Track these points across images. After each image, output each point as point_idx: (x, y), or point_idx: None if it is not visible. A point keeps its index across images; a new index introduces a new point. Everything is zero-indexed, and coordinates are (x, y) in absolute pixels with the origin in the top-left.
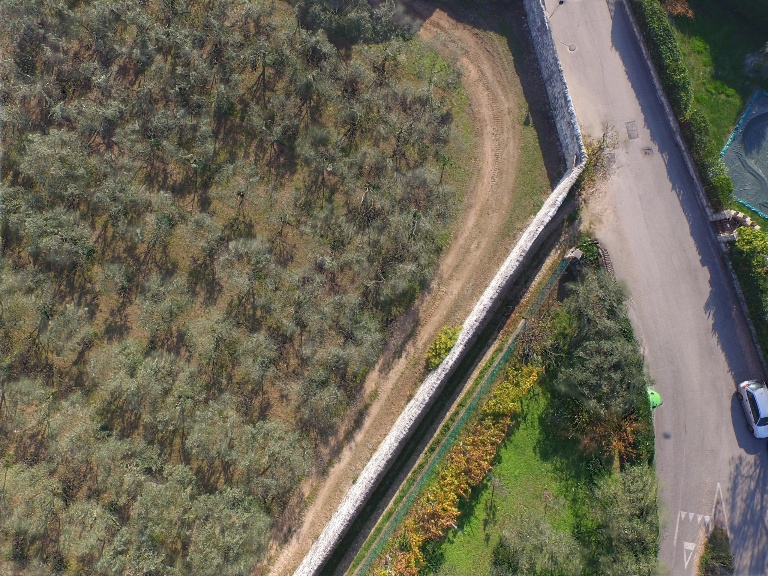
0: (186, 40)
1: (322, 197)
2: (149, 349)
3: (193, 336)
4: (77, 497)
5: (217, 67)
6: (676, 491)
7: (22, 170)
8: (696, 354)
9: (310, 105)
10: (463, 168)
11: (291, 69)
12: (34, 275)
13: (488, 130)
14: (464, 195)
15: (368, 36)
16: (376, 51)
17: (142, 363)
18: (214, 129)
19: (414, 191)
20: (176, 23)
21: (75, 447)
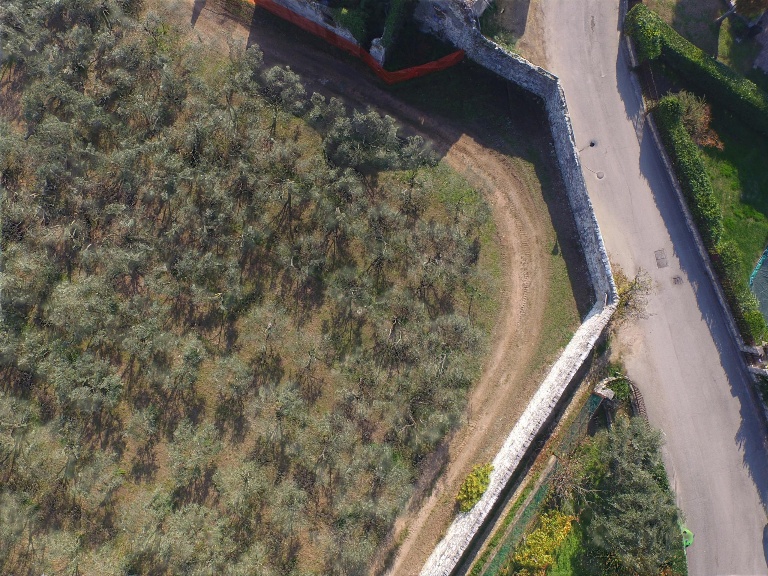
0: (214, 180)
1: (350, 329)
2: (177, 489)
3: (221, 475)
4: None
5: (245, 208)
6: None
7: (51, 322)
8: (727, 486)
9: (337, 234)
10: (491, 298)
11: (317, 197)
12: (60, 412)
13: (516, 259)
14: (493, 326)
15: (395, 165)
16: (402, 178)
17: (170, 504)
18: (240, 259)
19: (442, 323)
20: (204, 163)
21: None
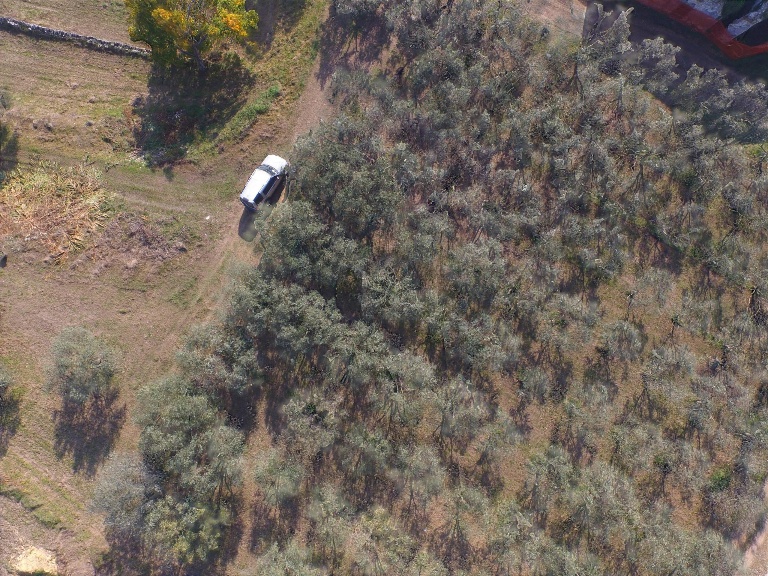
0: (600, 148)
1: (709, 298)
2: (551, 449)
3: (593, 437)
4: None
5: None
6: None
7: (467, 282)
8: None
9: (691, 205)
10: None
11: (669, 168)
12: (431, 373)
13: None
14: None
15: (750, 138)
16: (752, 151)
17: (546, 464)
18: None
19: None
20: None
21: (485, 547)
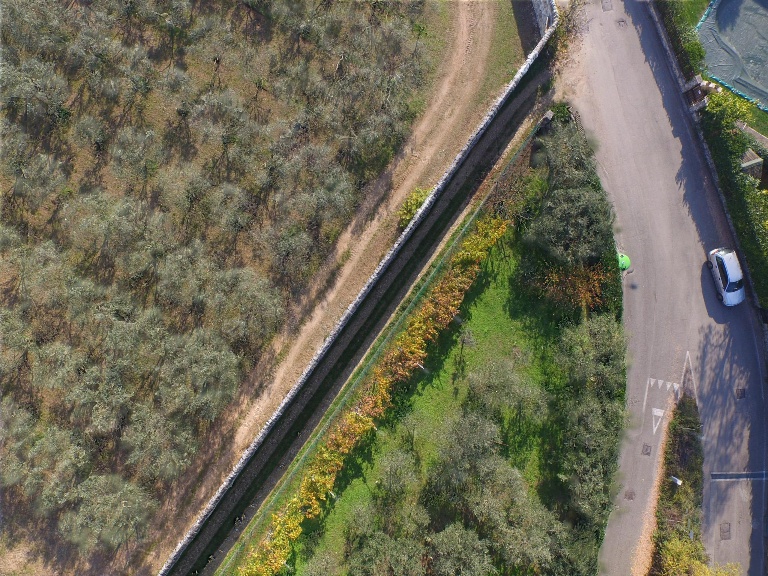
0: None
1: (297, 64)
2: (123, 208)
3: (167, 197)
4: (50, 350)
5: None
6: (646, 358)
7: None
8: (667, 224)
9: None
10: (438, 38)
11: None
12: (10, 137)
13: (463, 1)
14: (438, 64)
15: None
16: None
17: None
18: None
19: (389, 59)
20: None
21: (49, 302)
